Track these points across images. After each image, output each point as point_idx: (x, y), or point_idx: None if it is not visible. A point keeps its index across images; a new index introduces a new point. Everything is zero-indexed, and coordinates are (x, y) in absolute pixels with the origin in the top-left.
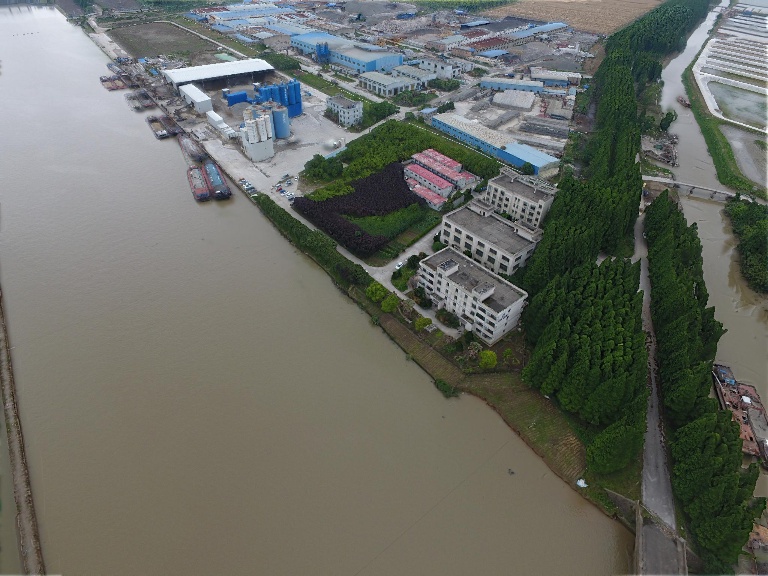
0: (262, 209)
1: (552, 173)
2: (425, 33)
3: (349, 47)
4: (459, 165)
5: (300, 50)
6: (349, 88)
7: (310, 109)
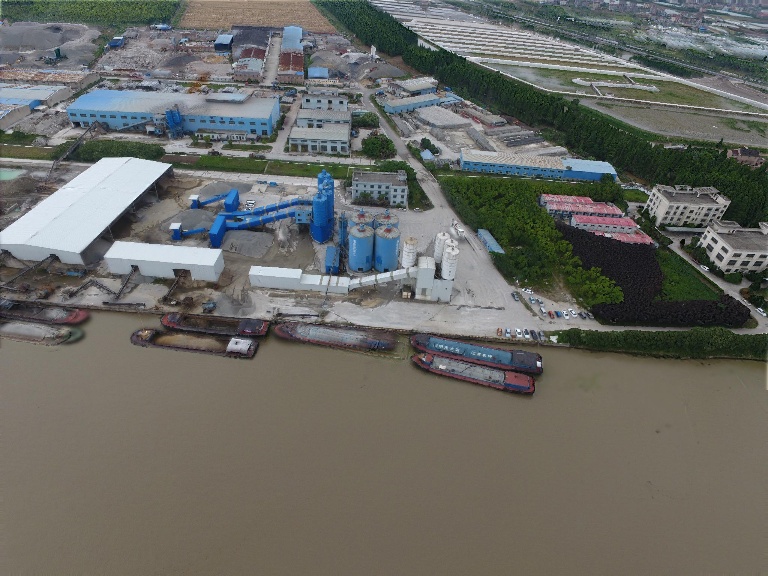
0: (593, 347)
1: None
2: (187, 61)
3: (199, 103)
4: (590, 199)
5: (104, 124)
6: (288, 158)
7: None
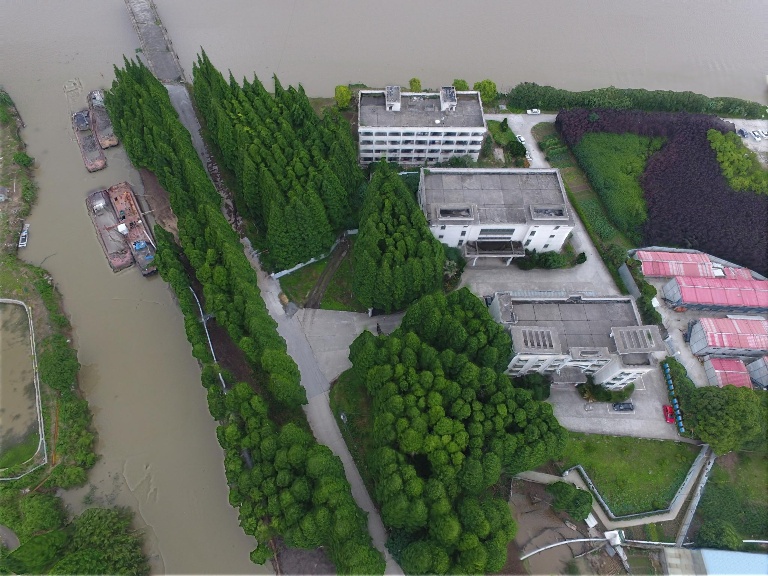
0: None
1: None
2: None
3: None
4: None
5: None
6: None
7: None
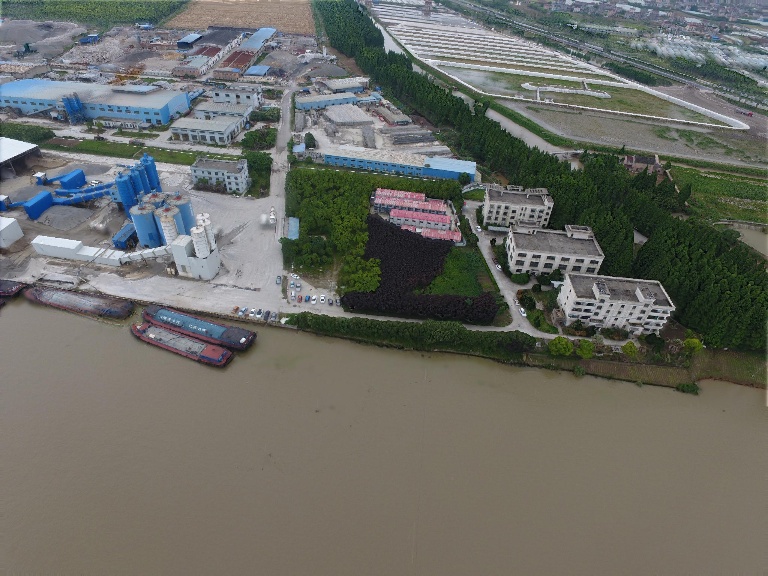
0: (319, 331)
1: (479, 175)
2: (143, 57)
3: (105, 93)
4: (424, 195)
5: (16, 109)
6: (166, 145)
7: (162, 186)
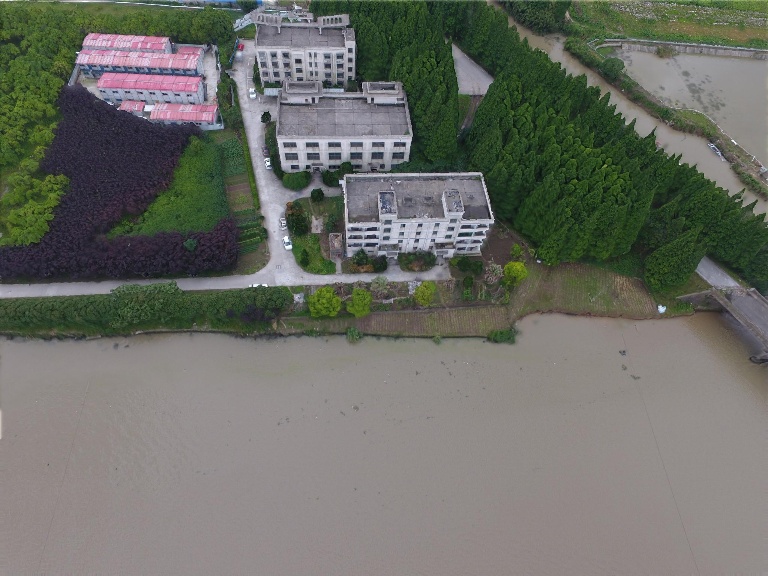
0: None
1: None
2: None
3: None
4: (165, 40)
5: None
6: None
7: None
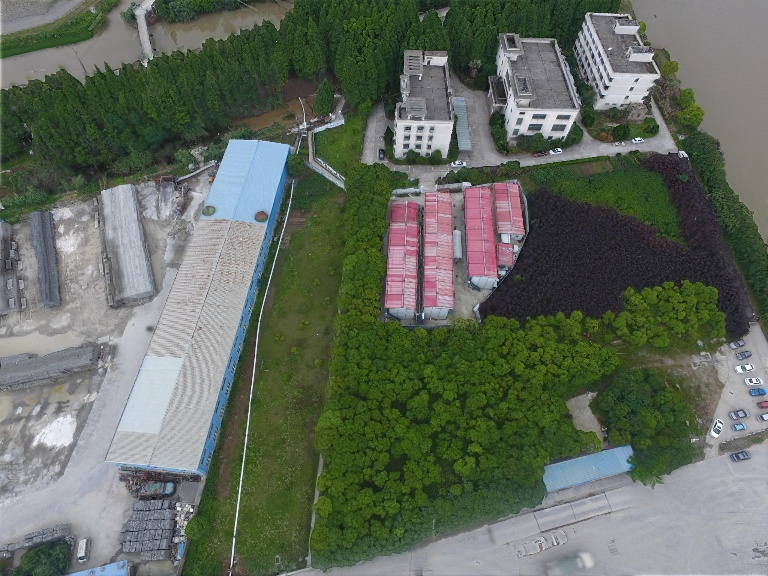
0: None
1: None
2: None
3: None
4: (401, 224)
5: None
6: None
7: None
